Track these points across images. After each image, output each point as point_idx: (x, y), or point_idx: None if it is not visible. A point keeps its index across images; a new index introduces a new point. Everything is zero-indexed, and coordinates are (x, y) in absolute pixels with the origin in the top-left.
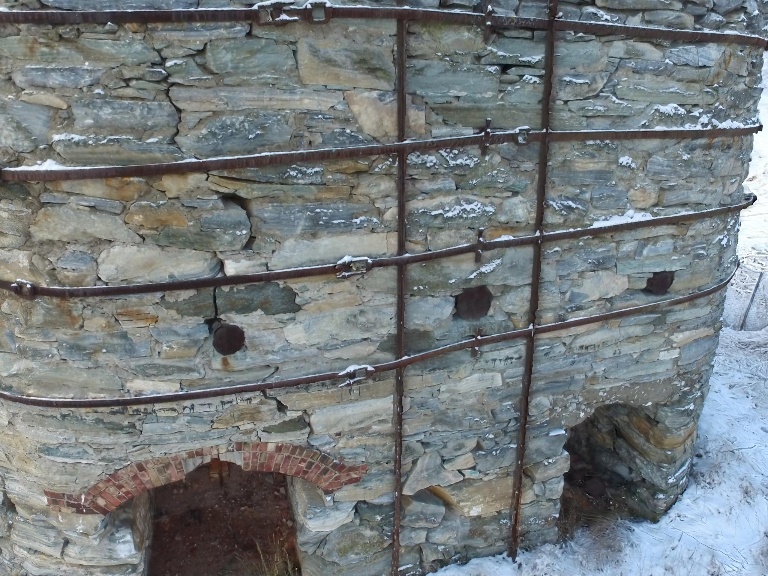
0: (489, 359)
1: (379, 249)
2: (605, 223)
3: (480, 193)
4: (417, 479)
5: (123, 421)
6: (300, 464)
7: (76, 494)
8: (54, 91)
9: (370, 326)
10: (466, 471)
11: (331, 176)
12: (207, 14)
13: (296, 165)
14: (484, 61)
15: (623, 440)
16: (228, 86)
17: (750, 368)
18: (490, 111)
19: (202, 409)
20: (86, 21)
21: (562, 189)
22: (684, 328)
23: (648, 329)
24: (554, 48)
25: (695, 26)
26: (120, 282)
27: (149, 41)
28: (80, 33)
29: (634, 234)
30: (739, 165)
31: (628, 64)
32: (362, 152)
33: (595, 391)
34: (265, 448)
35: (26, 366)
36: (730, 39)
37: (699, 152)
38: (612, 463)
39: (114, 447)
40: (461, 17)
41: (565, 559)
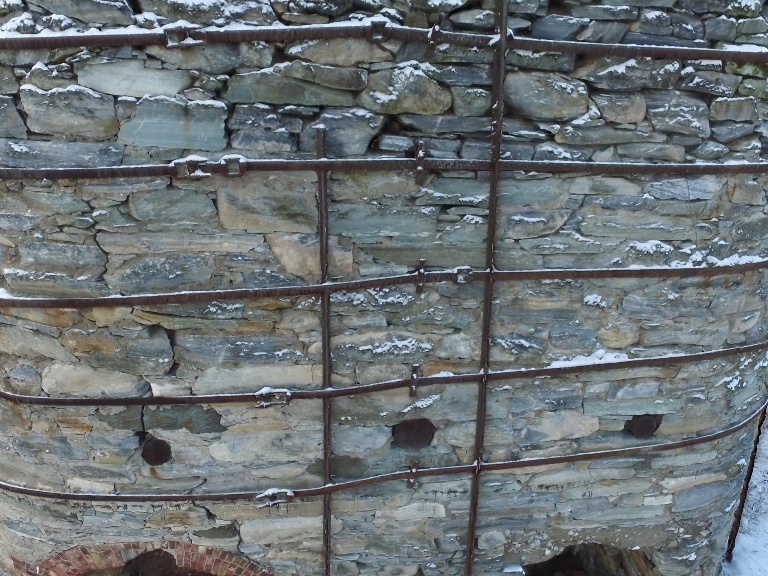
0: (429, 490)
1: (304, 380)
2: (566, 363)
3: (415, 330)
4: None
5: (67, 511)
6: (230, 568)
7: (33, 564)
8: (5, 232)
9: (296, 450)
10: None
11: (252, 312)
12: (128, 171)
13: (217, 301)
14: (419, 202)
15: (624, 571)
16: (150, 232)
17: None
18: (426, 250)
19: (135, 509)
20: (27, 177)
21: (513, 327)
22: (678, 474)
23: (627, 473)
24: (502, 187)
25: (686, 157)
26: (60, 395)
27: (79, 194)
28: (24, 186)
29: (604, 375)
30: (756, 300)
31: (595, 200)
32: (280, 293)
33: (563, 530)
34: (196, 549)
35: None
36: (733, 170)
37: (691, 291)
38: None
39: (61, 531)
40: (388, 163)
41: None
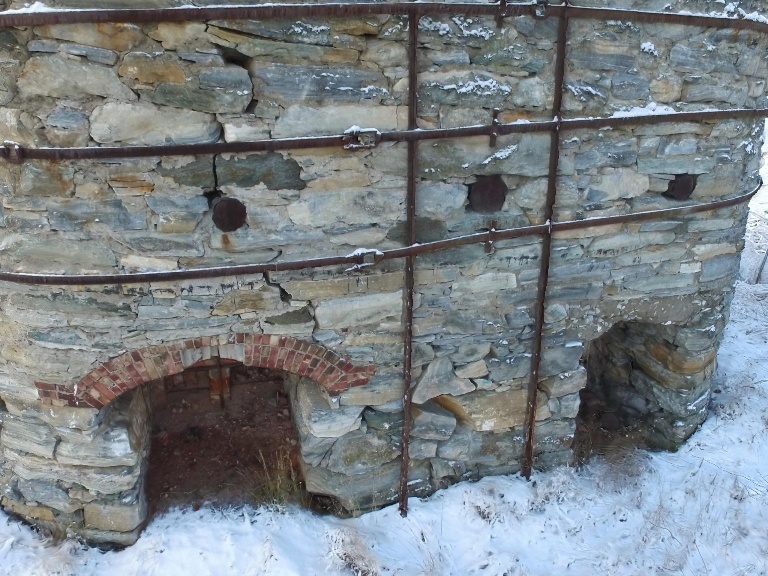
0: (503, 257)
1: (388, 124)
2: (626, 114)
3: (495, 70)
4: (427, 385)
5: (117, 302)
6: (304, 361)
7: (68, 384)
8: None
9: (379, 210)
10: (478, 380)
11: (338, 37)
12: None
13: (301, 21)
14: None
15: (639, 371)
16: None
17: (767, 317)
18: None
19: (201, 292)
20: None
21: (581, 73)
22: (706, 240)
23: (669, 237)
24: None
25: None
26: (114, 143)
27: None
28: None
29: (656, 129)
30: (765, 67)
31: None
32: (371, 10)
33: (613, 303)
34: (268, 341)
35: (15, 240)
36: None
37: (724, 44)
38: (628, 397)
39: (108, 332)
40: None
41: (581, 481)
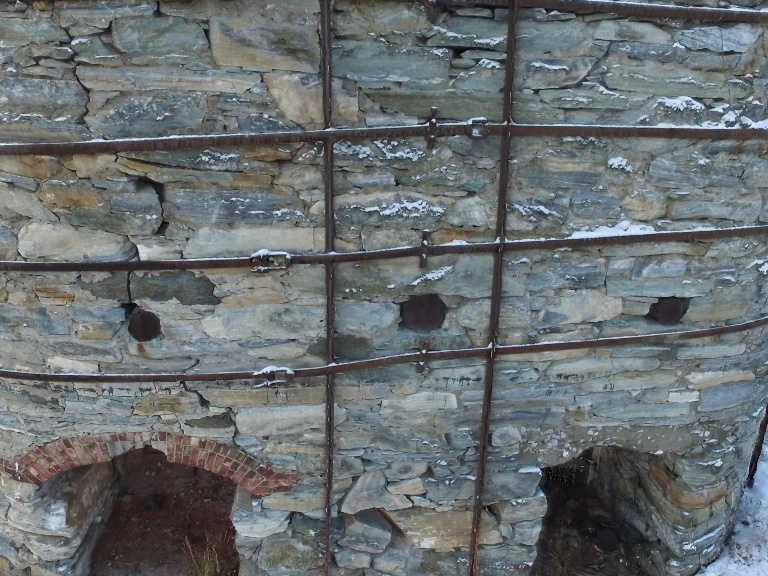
0: (440, 377)
1: (305, 245)
2: (588, 234)
3: (426, 191)
4: (356, 498)
5: (47, 396)
6: (225, 463)
7: (12, 461)
8: None
9: (297, 327)
10: (415, 497)
11: (248, 163)
12: None
13: (209, 150)
14: (431, 43)
15: (642, 490)
16: (135, 66)
17: None
18: (438, 99)
19: (121, 393)
20: None
21: (532, 191)
22: (705, 368)
23: (652, 364)
24: (521, 28)
25: (719, 3)
26: (38, 259)
27: (56, 19)
28: None
29: (629, 250)
30: None
31: (621, 48)
32: (278, 139)
33: (582, 429)
34: (189, 442)
35: None
36: None
37: (723, 156)
38: (630, 515)
39: (41, 420)
40: None
41: None
